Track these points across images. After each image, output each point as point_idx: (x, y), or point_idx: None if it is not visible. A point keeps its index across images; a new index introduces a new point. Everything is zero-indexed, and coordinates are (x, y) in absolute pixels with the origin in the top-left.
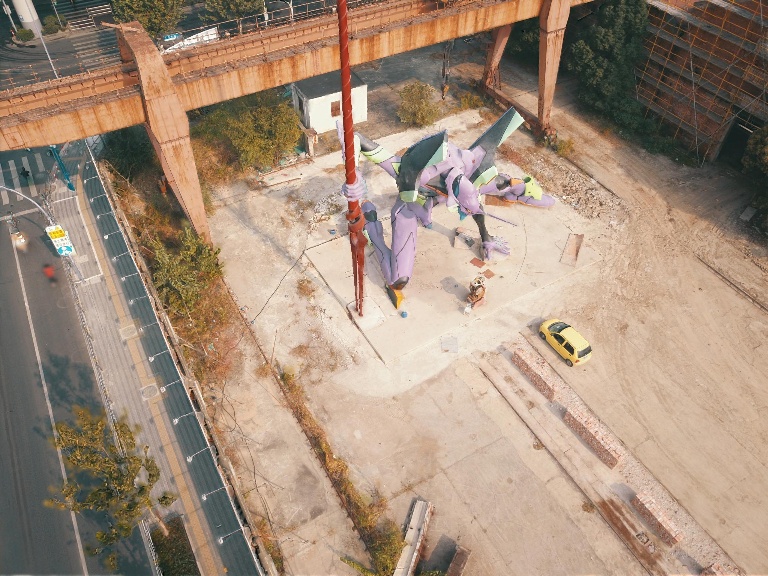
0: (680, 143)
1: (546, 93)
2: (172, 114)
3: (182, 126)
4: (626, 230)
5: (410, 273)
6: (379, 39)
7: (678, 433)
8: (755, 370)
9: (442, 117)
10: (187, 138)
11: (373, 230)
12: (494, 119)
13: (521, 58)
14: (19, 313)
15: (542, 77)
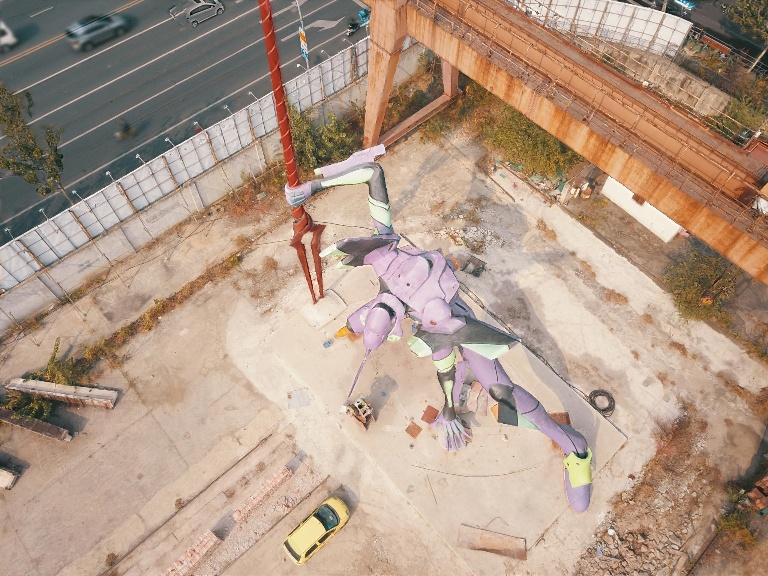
0: None
1: None
2: (387, 25)
3: (390, 42)
4: None
5: (356, 329)
6: (614, 151)
7: None
8: None
9: (727, 333)
10: (389, 55)
11: None
12: (762, 408)
13: None
14: None
15: None
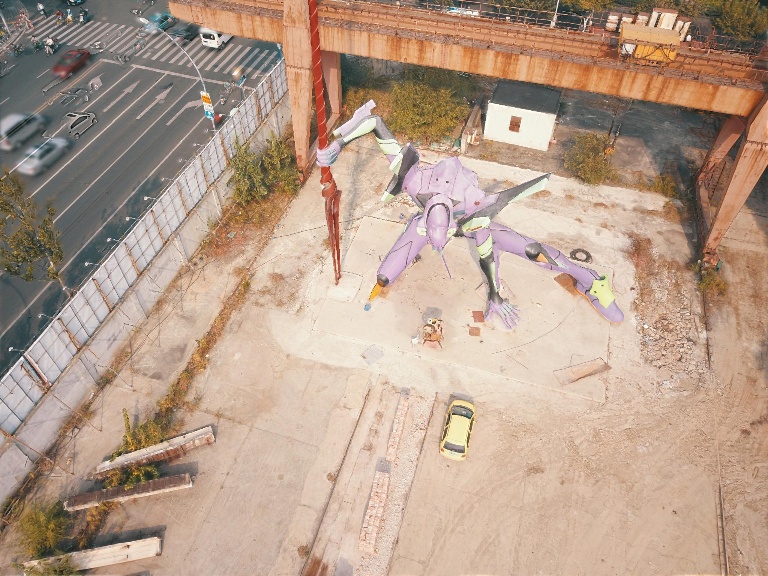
0: None
1: (723, 211)
2: (301, 45)
3: (306, 59)
4: (672, 400)
5: (391, 276)
6: (518, 60)
7: None
8: None
9: (621, 186)
10: (308, 70)
11: None
12: (672, 216)
13: None
14: (173, 143)
15: None
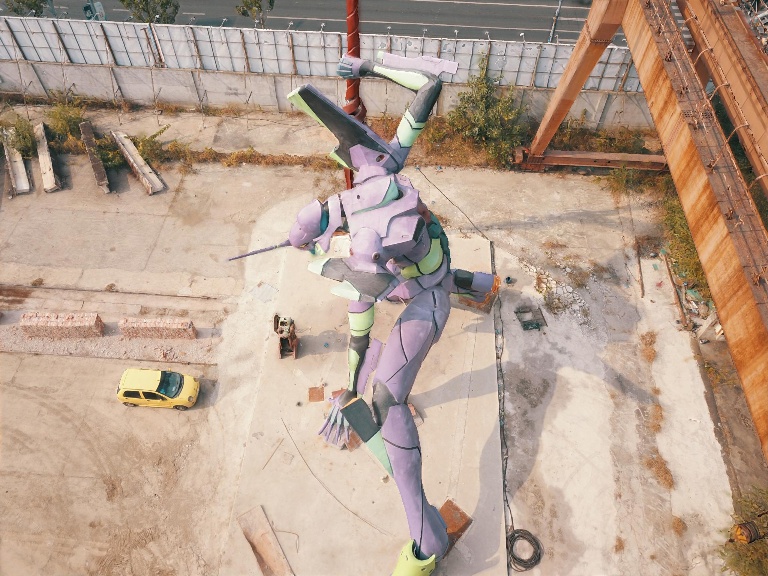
0: None
1: None
2: None
3: None
4: None
5: None
6: (717, 221)
7: None
8: None
9: None
10: None
11: None
12: None
13: None
14: None
15: None
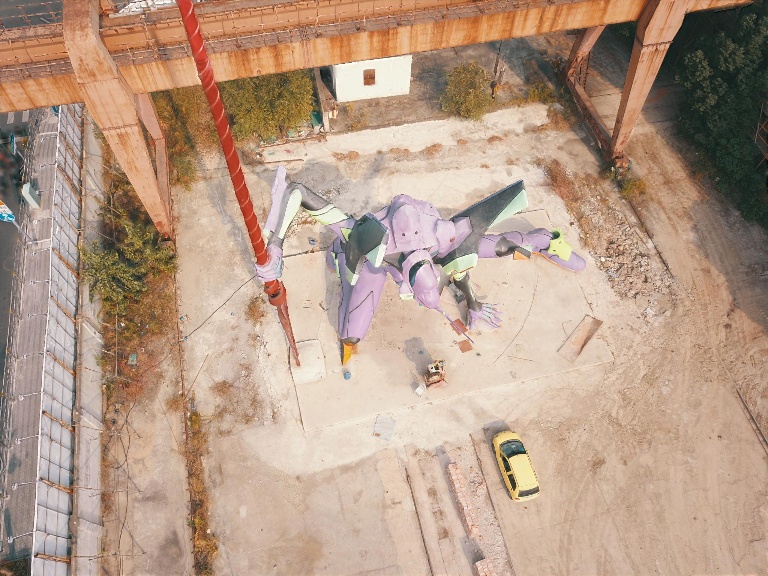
0: None
1: (626, 117)
2: (114, 100)
3: (127, 114)
4: (661, 326)
5: (362, 334)
6: (397, 33)
7: None
8: (738, 572)
9: (499, 107)
10: (135, 126)
11: (344, 263)
12: (561, 125)
13: None
14: None
15: (625, 96)
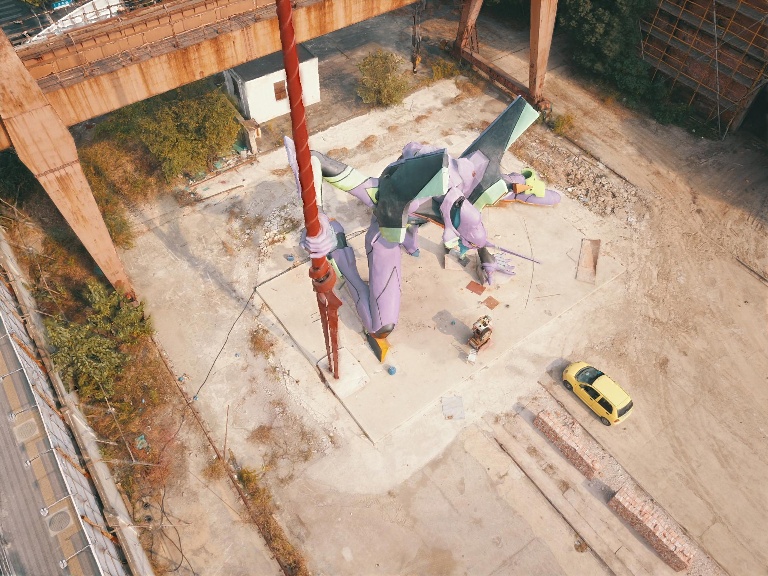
0: (695, 110)
1: (539, 58)
2: (48, 134)
3: (66, 149)
4: (648, 228)
5: (396, 319)
6: (332, 5)
7: (750, 509)
8: None
9: (411, 91)
10: (76, 164)
11: (342, 259)
12: (474, 91)
13: (497, 10)
14: None
15: (534, 39)
